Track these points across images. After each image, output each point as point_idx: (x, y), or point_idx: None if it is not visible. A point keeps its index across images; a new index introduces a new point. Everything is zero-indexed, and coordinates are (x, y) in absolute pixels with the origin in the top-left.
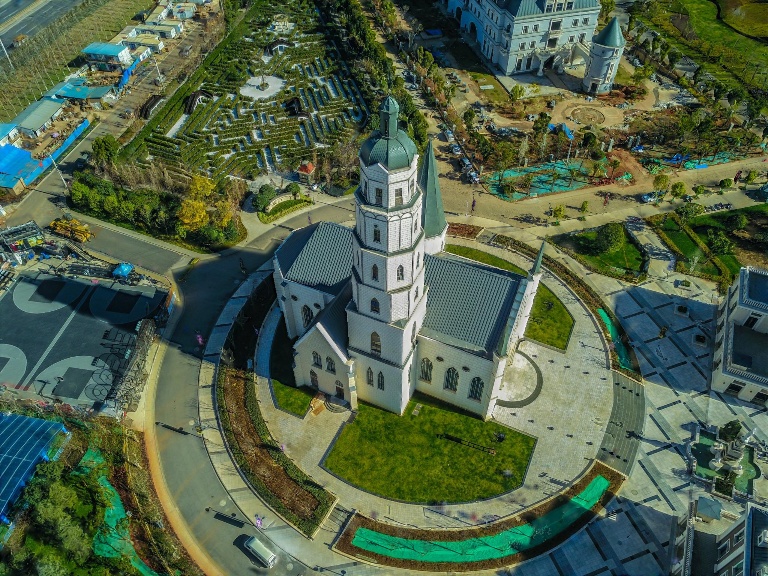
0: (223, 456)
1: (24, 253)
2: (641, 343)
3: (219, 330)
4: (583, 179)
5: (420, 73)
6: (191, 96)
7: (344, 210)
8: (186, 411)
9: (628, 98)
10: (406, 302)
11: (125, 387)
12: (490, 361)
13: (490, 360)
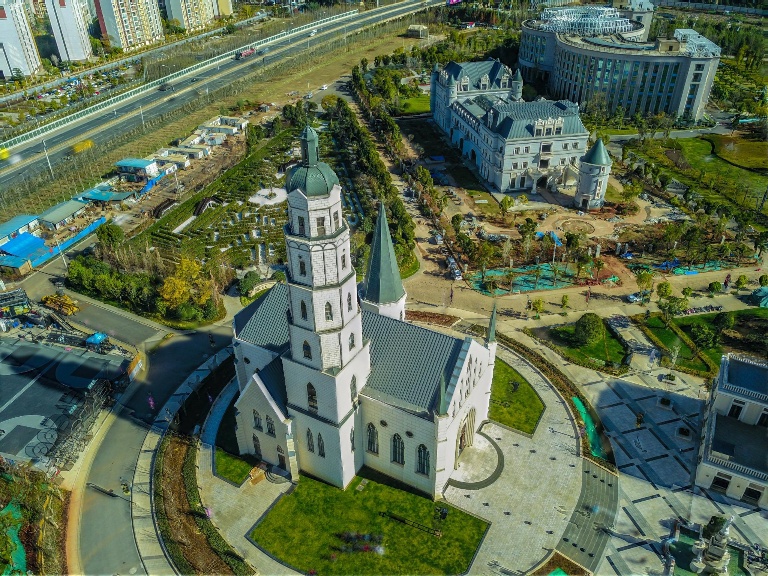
0: (147, 521)
1: (9, 321)
2: (618, 433)
3: (176, 399)
4: (568, 280)
5: (419, 189)
6: (202, 200)
7: None
8: (121, 474)
9: (619, 214)
10: (337, 346)
11: (66, 446)
12: (431, 422)
13: (431, 421)
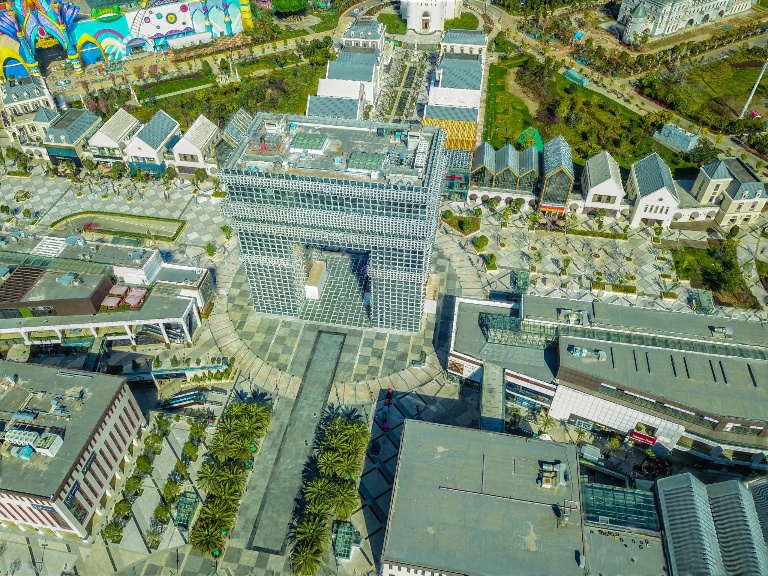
0: None
1: None
2: None
3: None
4: None
5: (598, 6)
6: None
7: (485, 6)
8: None
9: None
10: None
11: None
12: None
13: None
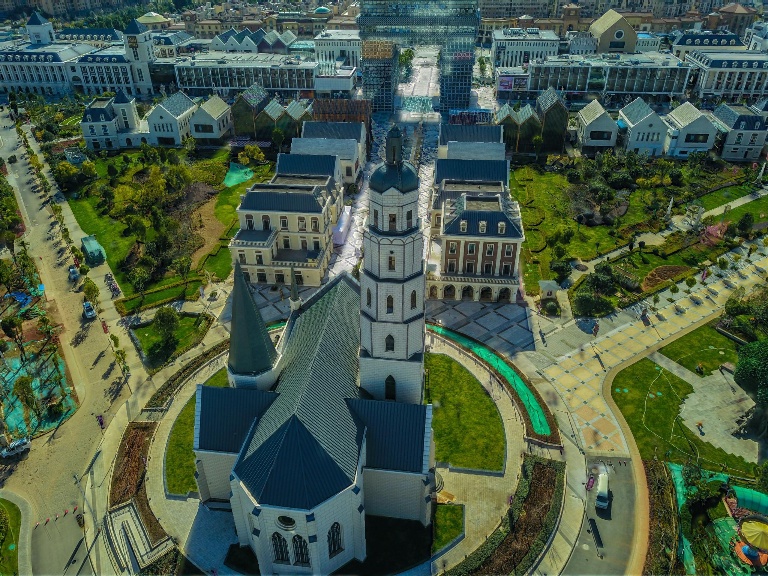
0: (543, 571)
1: None
2: (284, 315)
3: None
4: (45, 356)
5: None
6: None
7: None
8: None
9: None
10: None
11: None
12: None
13: None
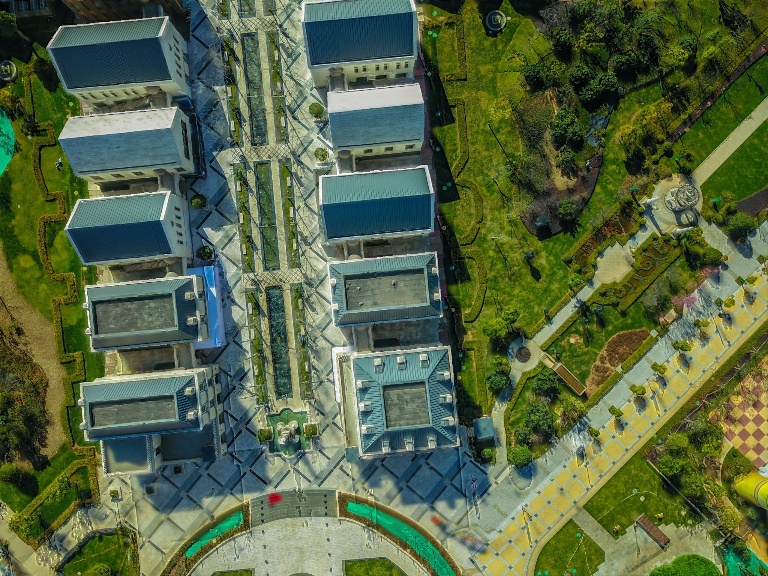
0: None
1: None
2: (206, 512)
3: None
4: None
5: None
6: None
7: None
8: None
9: None
10: None
11: None
12: None
13: None
